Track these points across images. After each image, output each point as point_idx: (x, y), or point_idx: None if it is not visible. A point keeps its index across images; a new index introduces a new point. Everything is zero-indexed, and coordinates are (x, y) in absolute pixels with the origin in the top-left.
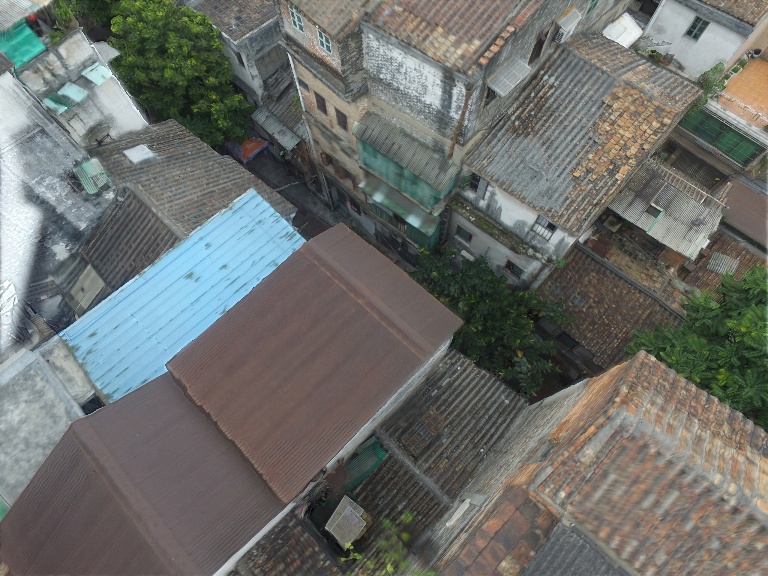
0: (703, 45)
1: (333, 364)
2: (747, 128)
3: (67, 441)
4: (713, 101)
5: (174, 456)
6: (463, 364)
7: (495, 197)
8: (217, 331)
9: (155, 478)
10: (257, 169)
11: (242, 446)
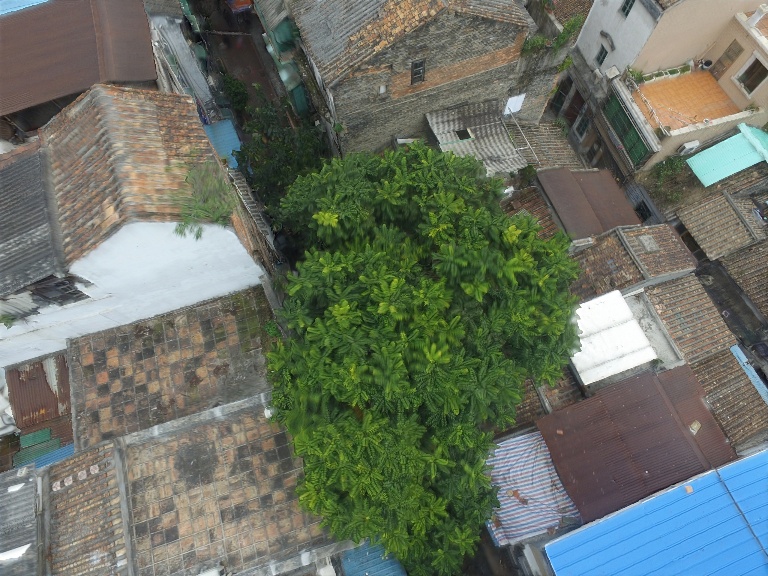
0: (629, 24)
1: (49, 61)
2: (642, 125)
3: None
4: (627, 90)
5: None
6: (237, 183)
7: None
8: (2, 17)
9: None
10: (249, 27)
11: None
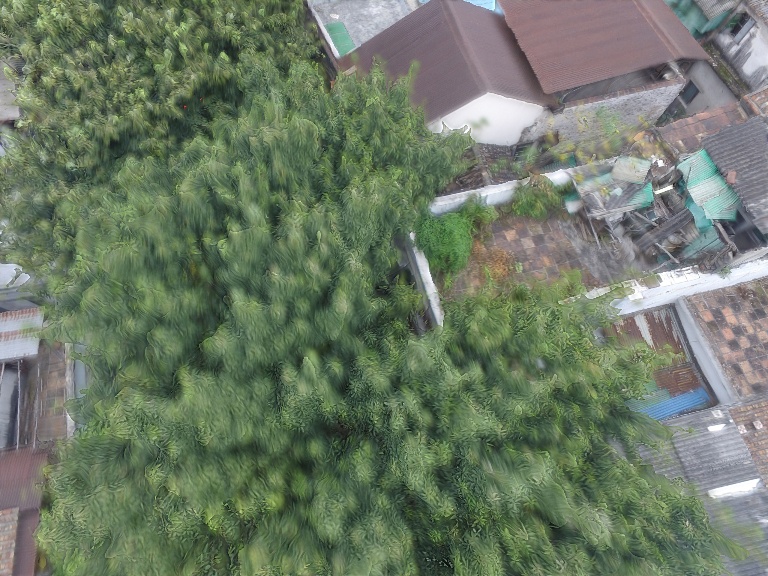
0: None
1: (610, 37)
2: None
3: (434, 2)
4: None
5: (487, 42)
6: None
7: (752, 40)
8: None
9: (476, 43)
10: None
11: (528, 58)
